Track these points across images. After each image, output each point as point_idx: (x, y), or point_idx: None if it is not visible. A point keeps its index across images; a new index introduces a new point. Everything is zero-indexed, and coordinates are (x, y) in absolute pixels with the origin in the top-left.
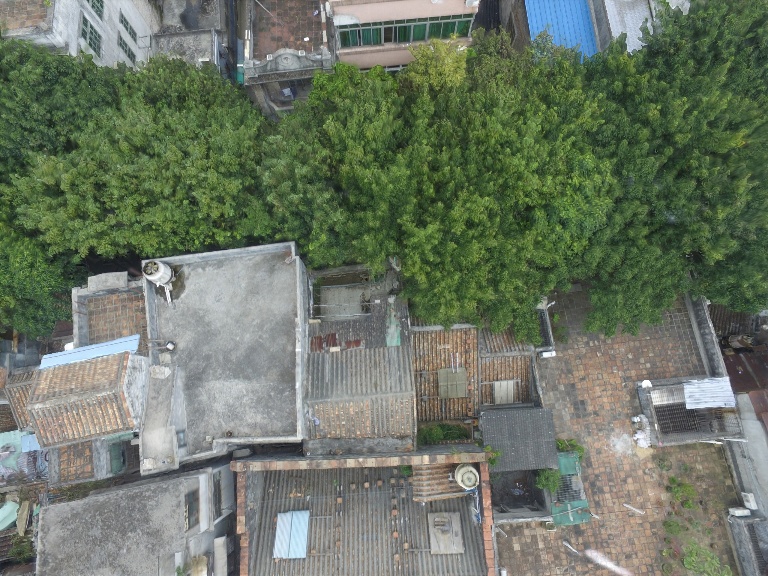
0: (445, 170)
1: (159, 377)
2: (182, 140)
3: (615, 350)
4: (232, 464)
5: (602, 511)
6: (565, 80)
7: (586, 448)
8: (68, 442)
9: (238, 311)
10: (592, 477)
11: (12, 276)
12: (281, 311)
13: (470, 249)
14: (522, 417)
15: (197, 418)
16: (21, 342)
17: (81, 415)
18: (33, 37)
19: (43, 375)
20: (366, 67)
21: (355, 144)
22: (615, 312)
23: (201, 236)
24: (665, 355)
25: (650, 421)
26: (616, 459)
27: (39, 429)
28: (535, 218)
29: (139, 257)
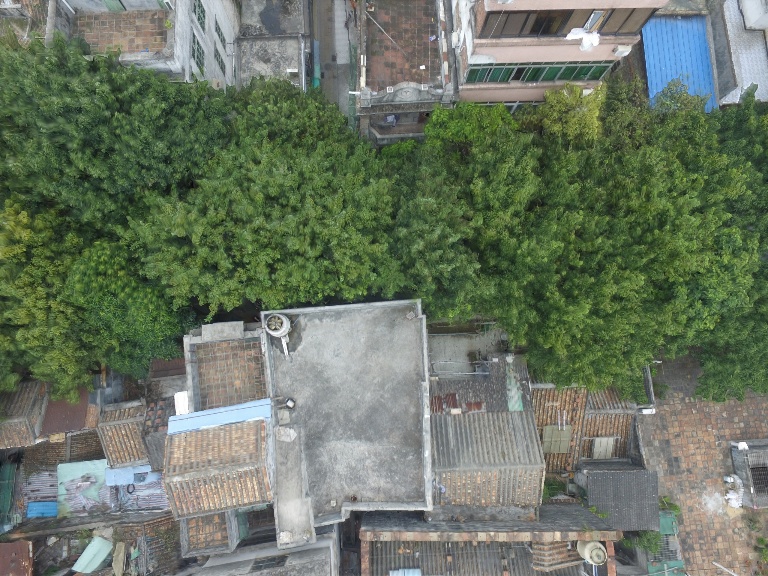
0: (597, 242)
1: (285, 440)
2: (316, 190)
3: (710, 408)
4: (362, 533)
5: (692, 568)
6: (699, 136)
7: (678, 505)
8: (203, 513)
9: (358, 368)
10: (683, 534)
11: (129, 327)
12: (403, 370)
13: (616, 326)
14: (627, 479)
15: (319, 480)
16: (108, 374)
17: (219, 488)
18: (151, 62)
19: (175, 442)
20: (482, 101)
21: (499, 205)
22: (731, 381)
23: (327, 290)
24: (759, 415)
25: (745, 483)
26: (707, 517)
27: (175, 500)
28: (674, 290)
29: (254, 305)
